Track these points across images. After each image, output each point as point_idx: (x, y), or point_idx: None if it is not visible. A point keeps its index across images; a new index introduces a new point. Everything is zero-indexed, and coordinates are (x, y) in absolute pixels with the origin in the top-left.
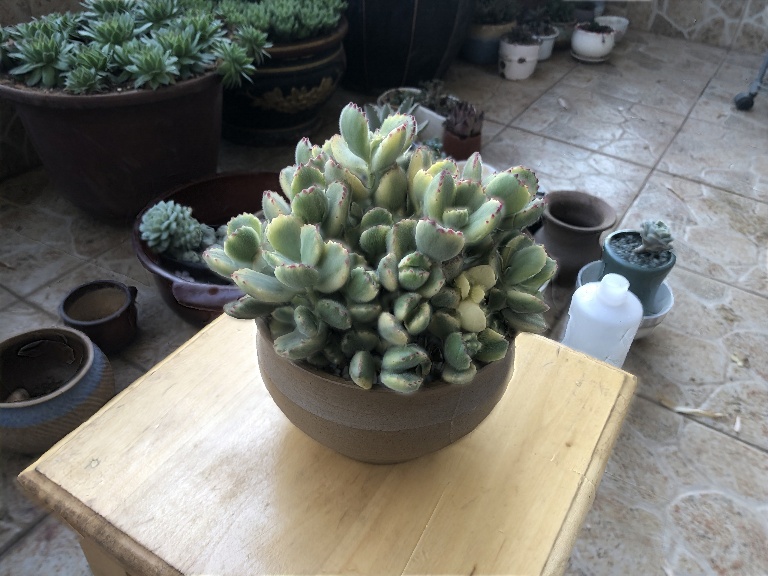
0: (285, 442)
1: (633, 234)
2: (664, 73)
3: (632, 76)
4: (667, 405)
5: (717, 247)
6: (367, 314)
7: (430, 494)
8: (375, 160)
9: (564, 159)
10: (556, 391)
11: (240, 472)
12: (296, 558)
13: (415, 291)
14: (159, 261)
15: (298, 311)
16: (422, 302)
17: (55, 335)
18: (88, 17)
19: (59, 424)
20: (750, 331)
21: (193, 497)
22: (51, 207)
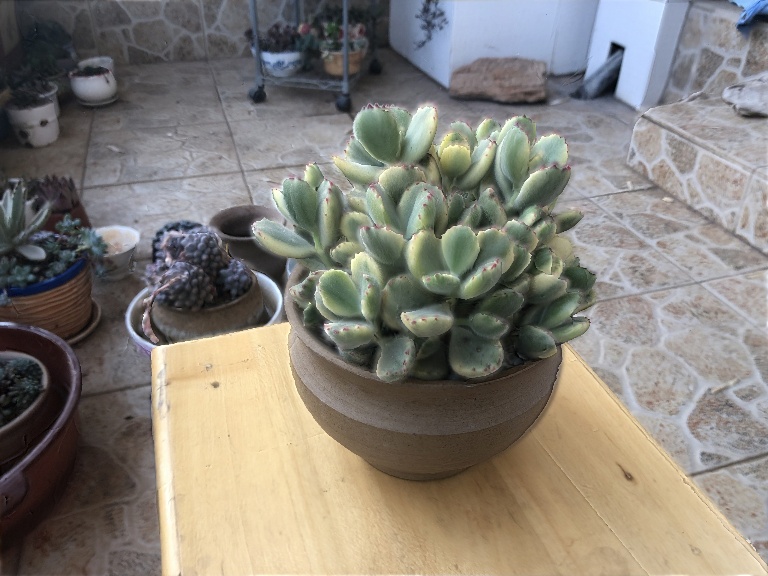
0: (394, 511)
1: None
2: (175, 94)
3: (151, 105)
4: None
5: None
6: (528, 285)
7: (533, 448)
8: (418, 152)
9: (163, 195)
10: None
11: (399, 568)
12: None
13: None
14: None
15: (489, 317)
16: None
17: None
18: None
19: None
20: None
21: None
22: None
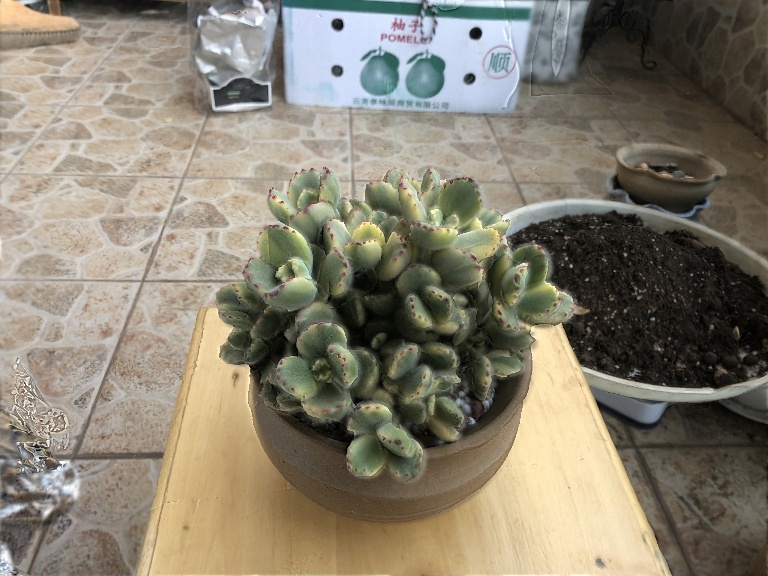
0: None
1: None
2: None
3: None
4: None
5: None
6: None
7: None
8: None
9: None
10: None
11: None
12: None
13: None
14: None
15: None
16: None
17: None
18: None
19: (767, 573)
20: None
21: None
22: None
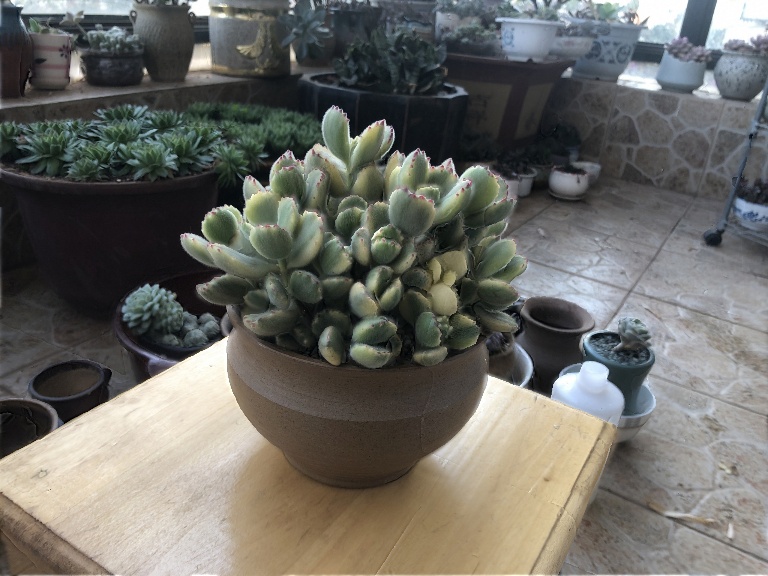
0: (249, 464)
1: (612, 335)
2: (636, 212)
3: (606, 213)
4: (655, 509)
5: (697, 362)
6: (339, 285)
7: (399, 517)
8: (354, 155)
9: (544, 279)
10: (534, 432)
11: (198, 488)
12: (250, 571)
13: (387, 264)
14: (138, 343)
15: (270, 279)
16: (394, 278)
17: (20, 407)
18: (98, 124)
19: None
20: (736, 440)
21: (144, 509)
22: (36, 300)
